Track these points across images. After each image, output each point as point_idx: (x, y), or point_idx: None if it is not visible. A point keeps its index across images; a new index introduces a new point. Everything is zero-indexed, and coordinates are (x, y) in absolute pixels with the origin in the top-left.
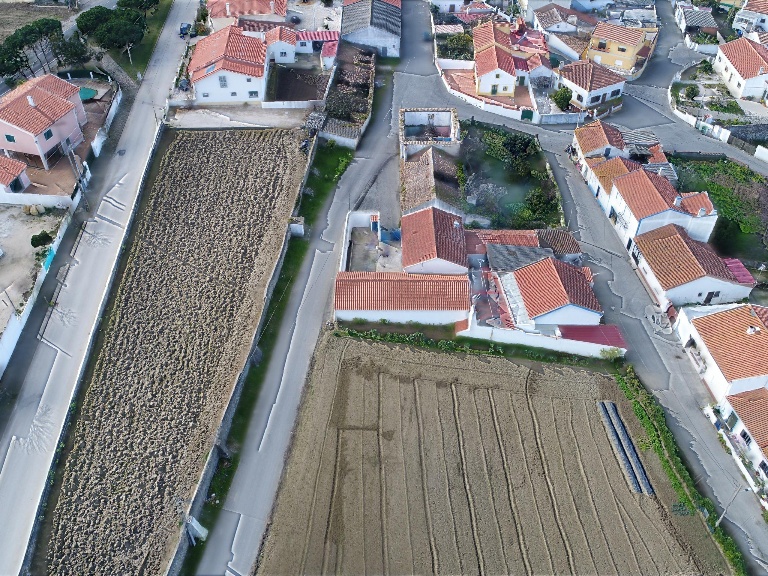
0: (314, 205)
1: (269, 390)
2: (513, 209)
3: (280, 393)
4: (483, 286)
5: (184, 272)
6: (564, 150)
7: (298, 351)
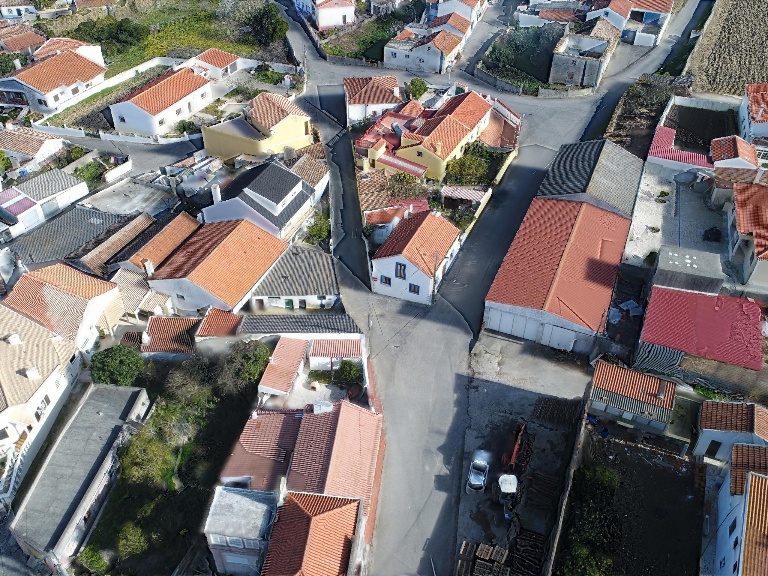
0: (682, 54)
1: (705, 1)
2: (533, 43)
3: (700, 0)
4: (588, 2)
5: (767, 29)
6: (454, 71)
7: (692, 8)
